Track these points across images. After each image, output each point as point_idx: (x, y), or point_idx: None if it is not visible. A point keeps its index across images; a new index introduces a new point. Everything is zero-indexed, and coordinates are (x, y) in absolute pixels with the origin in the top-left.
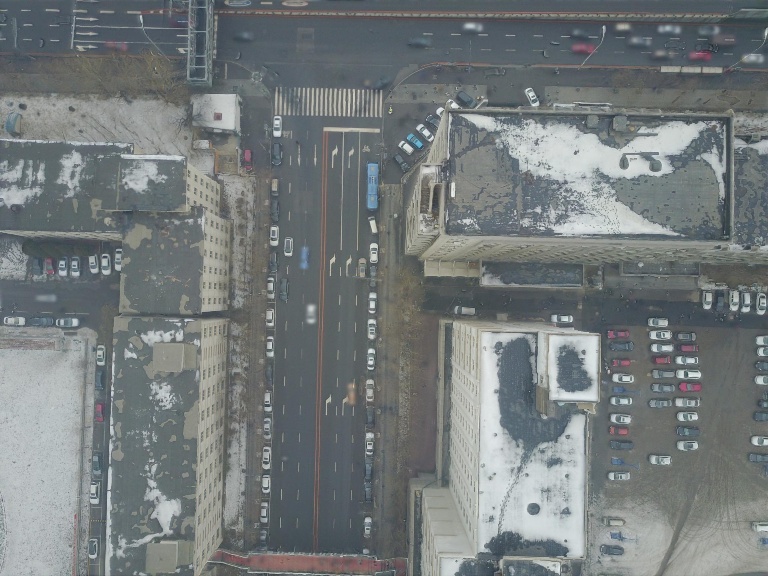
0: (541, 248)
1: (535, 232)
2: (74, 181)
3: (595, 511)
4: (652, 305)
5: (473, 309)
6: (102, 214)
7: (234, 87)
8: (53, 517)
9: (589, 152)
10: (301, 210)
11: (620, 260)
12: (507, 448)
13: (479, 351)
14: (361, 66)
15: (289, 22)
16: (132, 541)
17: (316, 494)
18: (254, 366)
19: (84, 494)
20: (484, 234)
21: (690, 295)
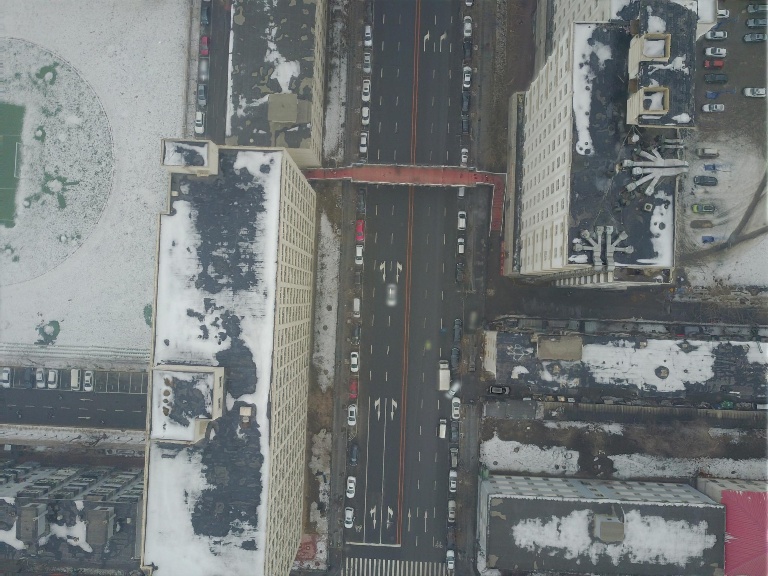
0: None
1: None
2: None
3: (689, 144)
4: None
5: None
6: None
7: None
8: (159, 146)
9: None
10: None
11: None
12: None
13: None
14: None
15: None
16: (252, 100)
17: (414, 127)
18: (354, 4)
19: (189, 124)
20: None
21: None
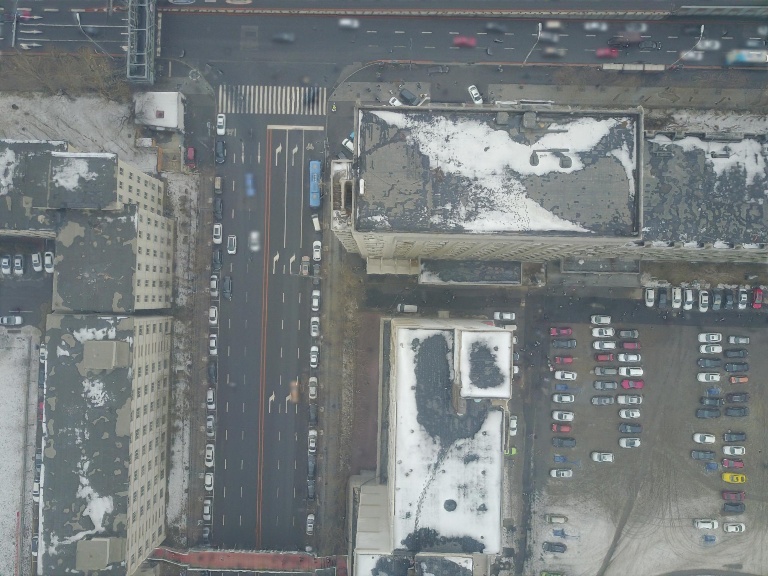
0: (463, 245)
1: (445, 229)
2: (8, 179)
3: (538, 508)
4: (595, 302)
5: (415, 307)
6: (36, 212)
7: (178, 85)
8: None
9: (499, 149)
10: (245, 208)
11: (556, 257)
12: (424, 445)
13: (396, 348)
14: (305, 64)
15: (233, 20)
16: (64, 538)
17: (259, 491)
18: (197, 364)
19: (27, 492)
20: (394, 231)
21: (633, 292)
